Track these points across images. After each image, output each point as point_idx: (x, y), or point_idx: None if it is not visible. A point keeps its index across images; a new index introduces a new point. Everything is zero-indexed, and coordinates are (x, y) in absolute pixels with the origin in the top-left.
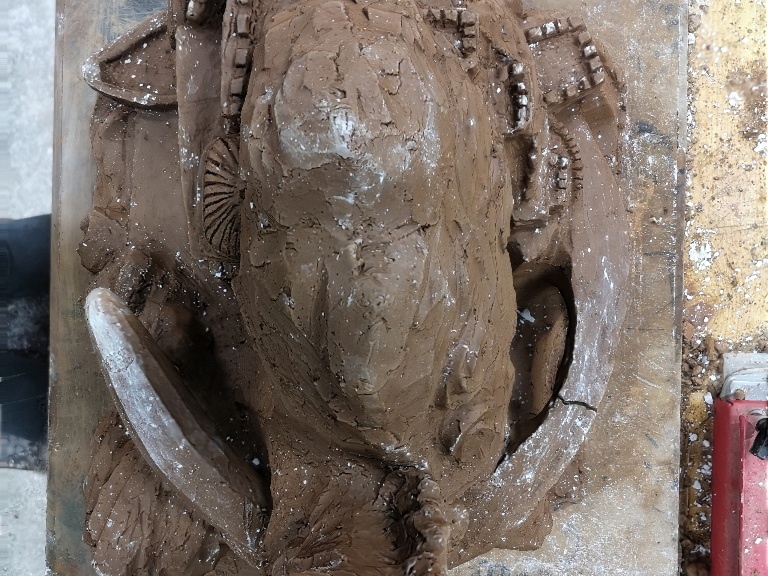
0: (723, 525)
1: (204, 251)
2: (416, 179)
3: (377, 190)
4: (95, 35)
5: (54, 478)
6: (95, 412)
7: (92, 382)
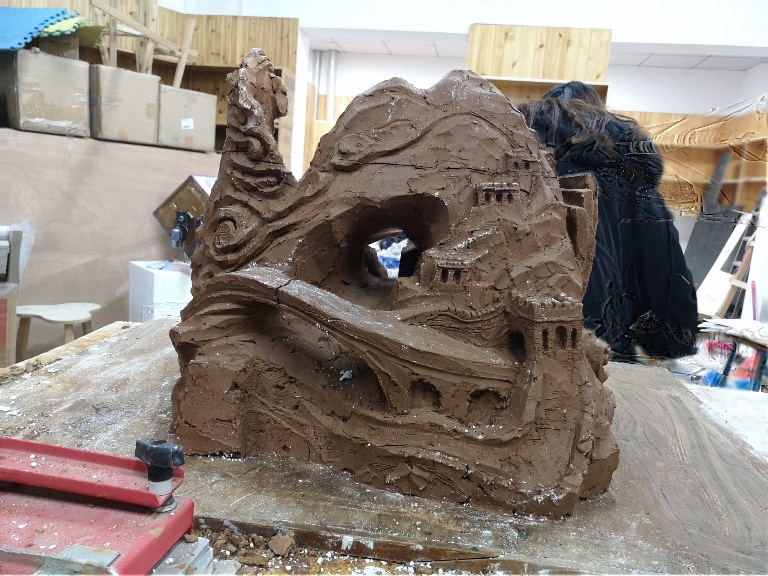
0: None
1: None
2: (446, 85)
3: None
4: None
5: None
6: None
7: None
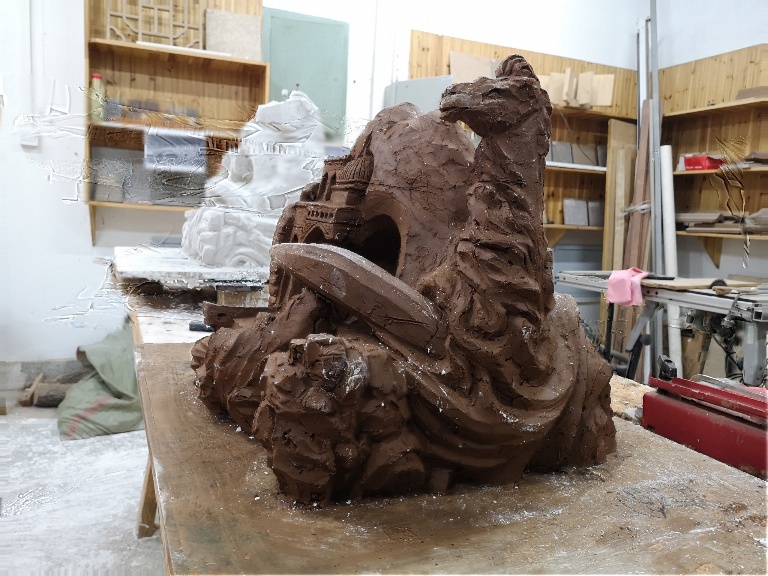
0: (714, 425)
1: (349, 185)
2: None
3: (422, 114)
4: (167, 374)
5: (173, 516)
6: (209, 477)
7: (201, 466)
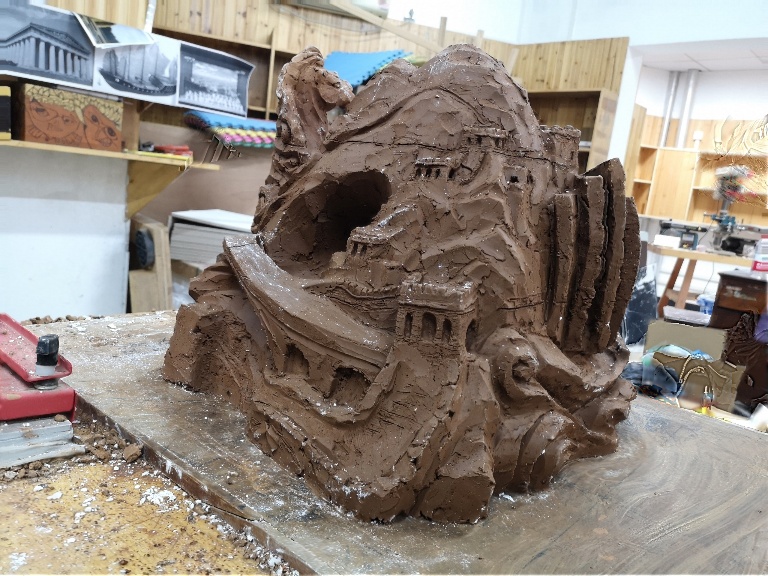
0: None
1: None
2: None
3: None
4: None
5: None
6: None
7: None
